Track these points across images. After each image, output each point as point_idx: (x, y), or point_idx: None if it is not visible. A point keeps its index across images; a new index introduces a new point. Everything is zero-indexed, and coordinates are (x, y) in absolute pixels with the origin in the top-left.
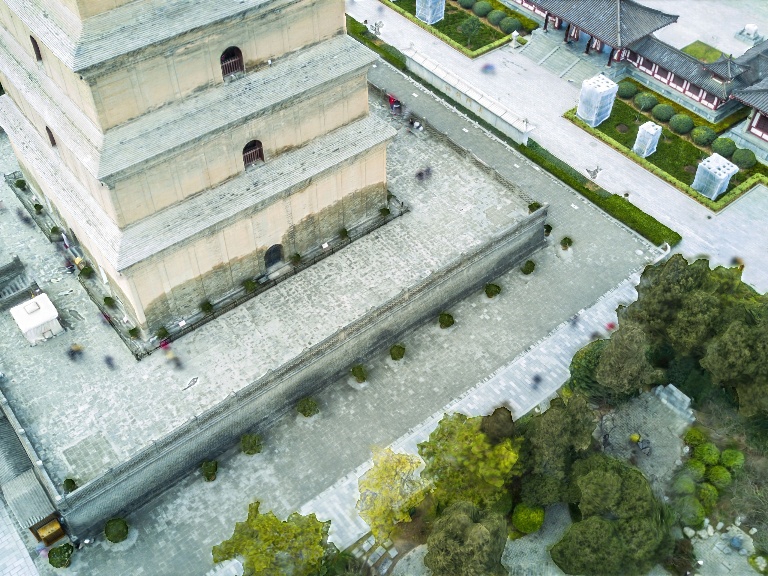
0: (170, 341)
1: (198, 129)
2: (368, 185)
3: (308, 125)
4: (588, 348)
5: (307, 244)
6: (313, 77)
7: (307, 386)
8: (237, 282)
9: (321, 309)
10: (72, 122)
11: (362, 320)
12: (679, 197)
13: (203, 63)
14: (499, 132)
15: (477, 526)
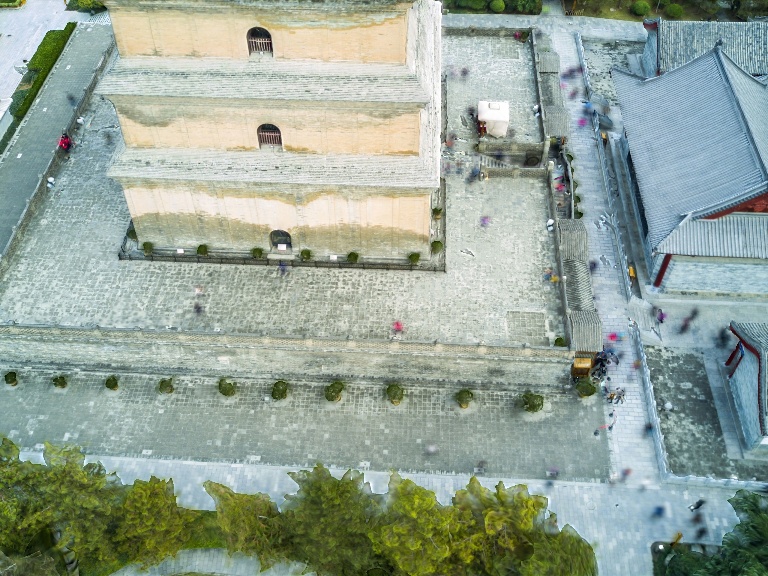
0: None
1: None
2: None
3: None
4: None
5: None
6: None
7: None
8: None
9: None
10: None
11: None
12: None
13: None
14: (6, 137)
15: None
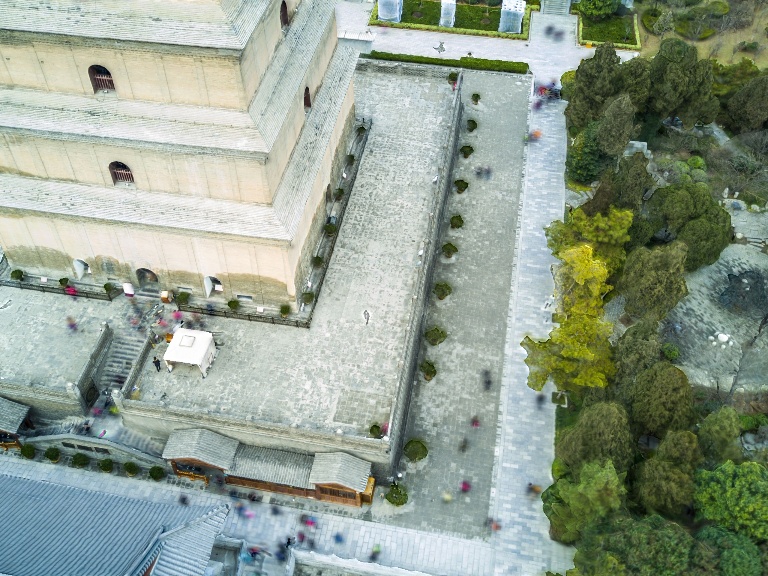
0: (316, 301)
1: (294, 83)
2: (350, 109)
3: (321, 63)
4: (583, 139)
5: (336, 179)
6: (323, 14)
7: (427, 277)
8: (319, 231)
9: (393, 216)
10: (194, 123)
11: (435, 203)
12: (497, 42)
13: (275, 22)
14: None
15: (670, 251)
